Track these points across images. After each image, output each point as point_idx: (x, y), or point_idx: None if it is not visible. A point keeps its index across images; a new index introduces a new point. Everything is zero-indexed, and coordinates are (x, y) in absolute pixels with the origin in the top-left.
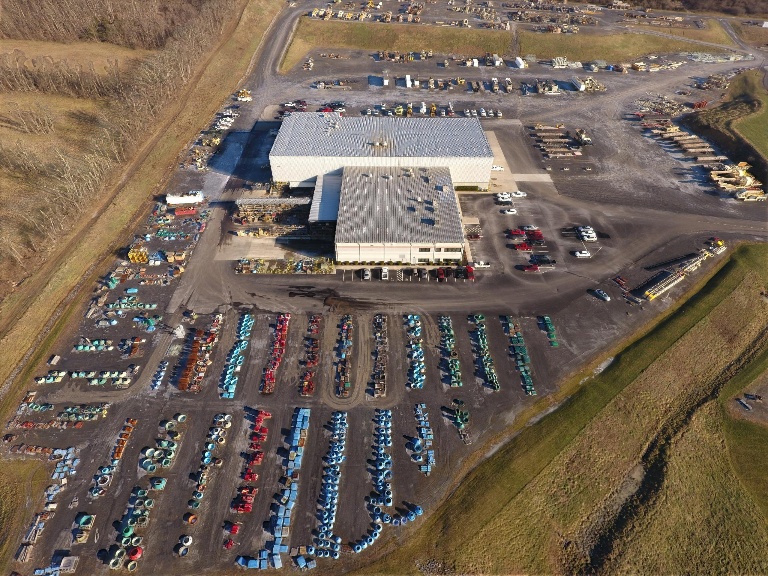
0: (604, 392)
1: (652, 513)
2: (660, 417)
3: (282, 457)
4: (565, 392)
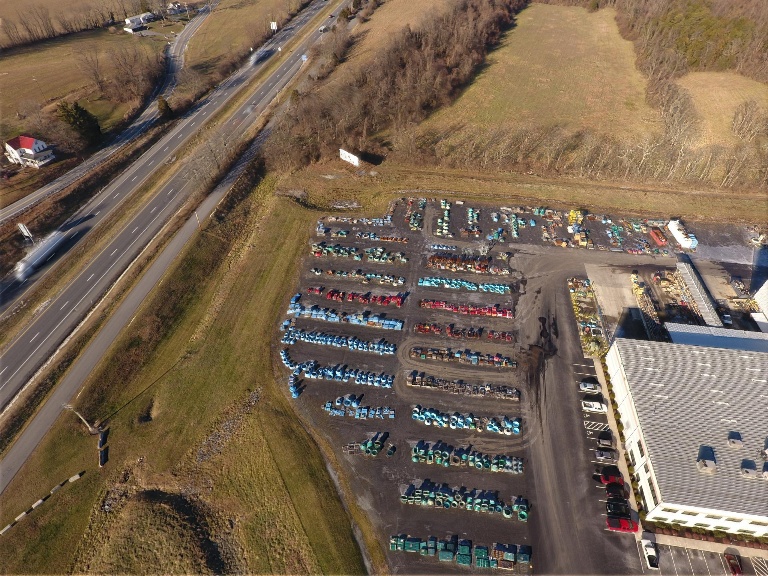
0: None
1: None
2: None
3: (362, 313)
4: None
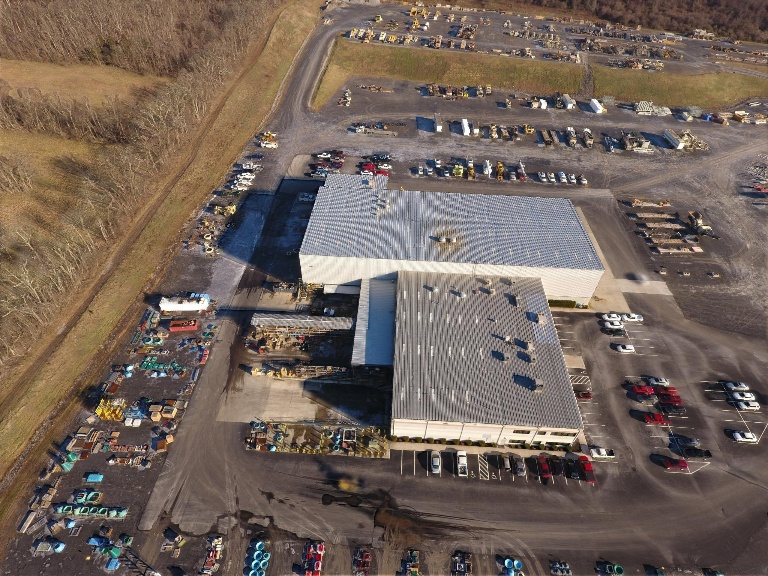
0: None
1: None
2: None
3: None
4: None
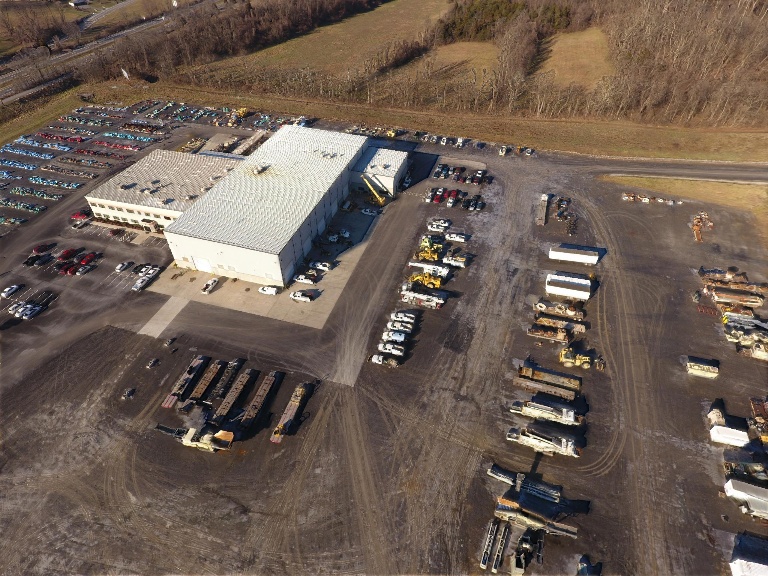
0: None
1: None
2: None
3: None
4: None
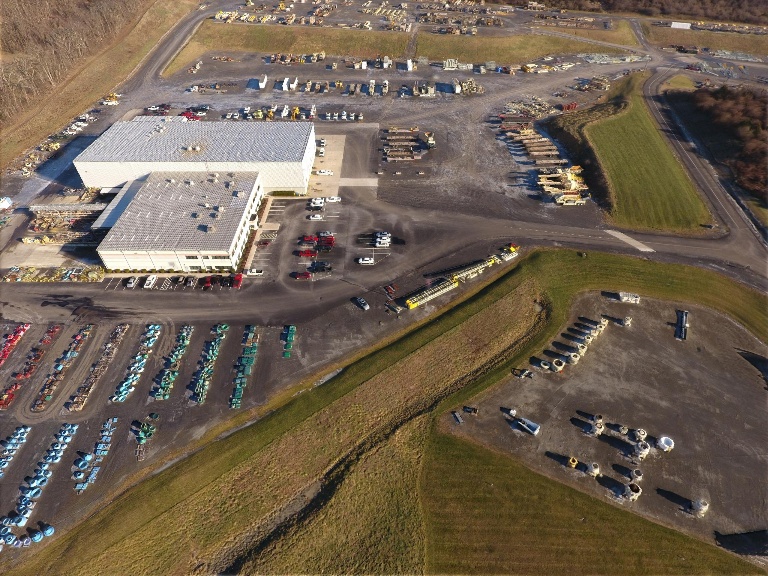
0: (311, 405)
1: (301, 533)
2: (364, 431)
3: None
4: (272, 405)
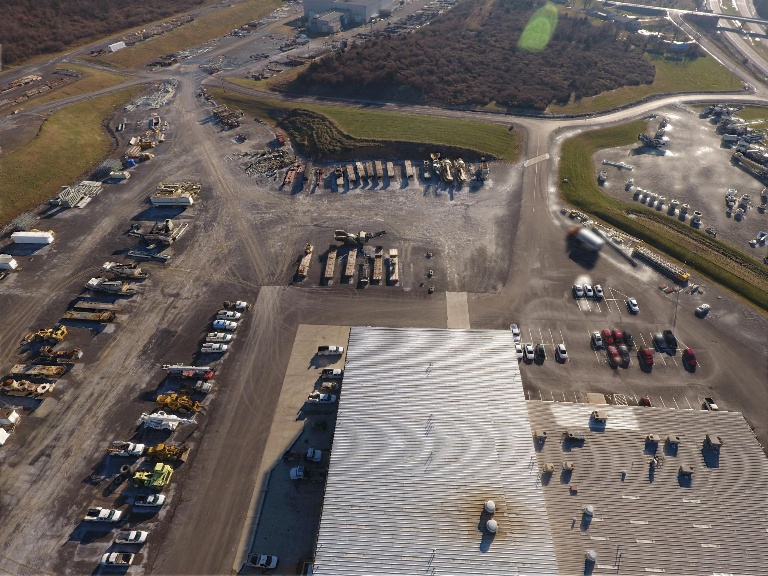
0: None
1: None
2: None
3: None
4: None
